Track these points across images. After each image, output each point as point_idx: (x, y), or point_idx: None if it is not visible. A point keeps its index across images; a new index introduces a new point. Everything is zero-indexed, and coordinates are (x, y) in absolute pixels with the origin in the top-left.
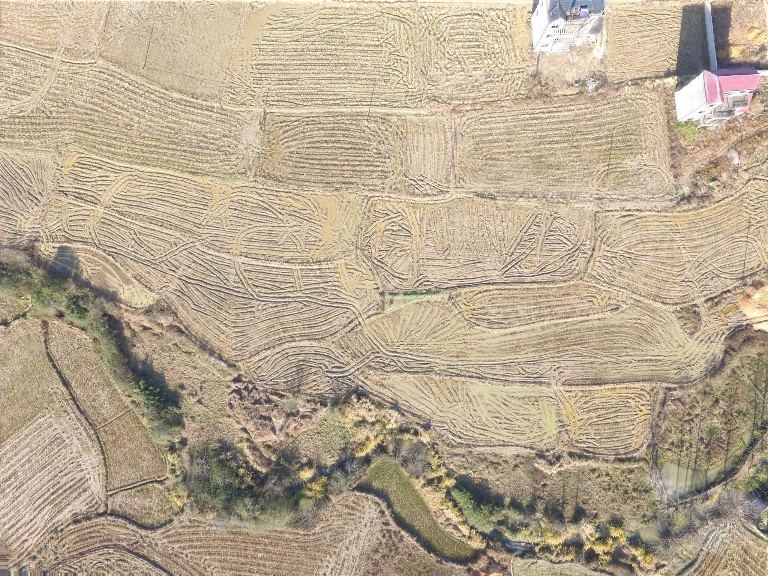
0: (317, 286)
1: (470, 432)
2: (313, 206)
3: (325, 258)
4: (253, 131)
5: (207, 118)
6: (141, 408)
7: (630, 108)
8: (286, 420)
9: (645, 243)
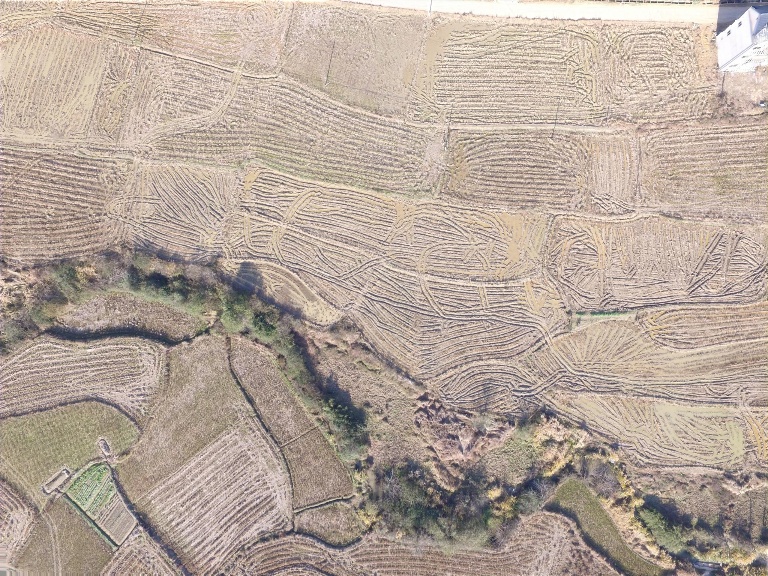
0: (503, 305)
1: (658, 452)
2: (498, 224)
3: (511, 276)
4: (437, 148)
5: (391, 134)
6: (326, 426)
7: None
8: (475, 439)
9: None
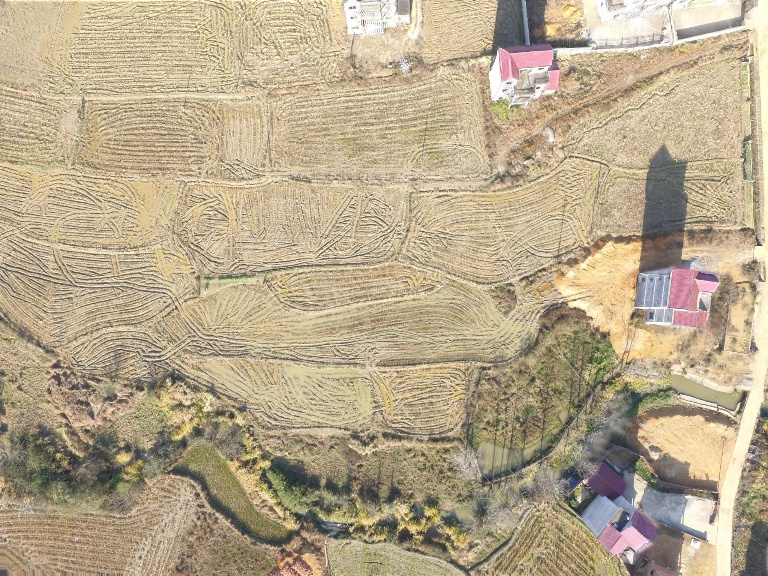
0: (134, 271)
1: (285, 414)
2: (130, 192)
3: (142, 244)
4: (72, 119)
5: (27, 107)
6: None
7: (446, 89)
8: (102, 404)
9: (460, 223)
